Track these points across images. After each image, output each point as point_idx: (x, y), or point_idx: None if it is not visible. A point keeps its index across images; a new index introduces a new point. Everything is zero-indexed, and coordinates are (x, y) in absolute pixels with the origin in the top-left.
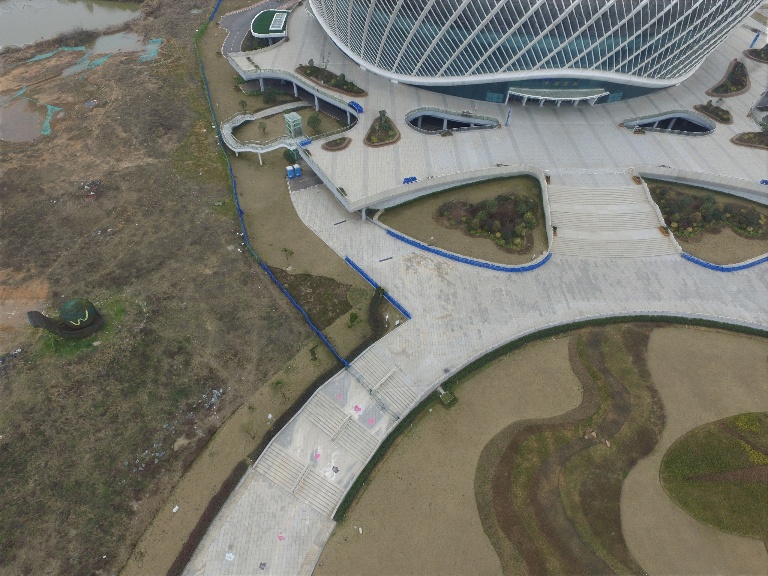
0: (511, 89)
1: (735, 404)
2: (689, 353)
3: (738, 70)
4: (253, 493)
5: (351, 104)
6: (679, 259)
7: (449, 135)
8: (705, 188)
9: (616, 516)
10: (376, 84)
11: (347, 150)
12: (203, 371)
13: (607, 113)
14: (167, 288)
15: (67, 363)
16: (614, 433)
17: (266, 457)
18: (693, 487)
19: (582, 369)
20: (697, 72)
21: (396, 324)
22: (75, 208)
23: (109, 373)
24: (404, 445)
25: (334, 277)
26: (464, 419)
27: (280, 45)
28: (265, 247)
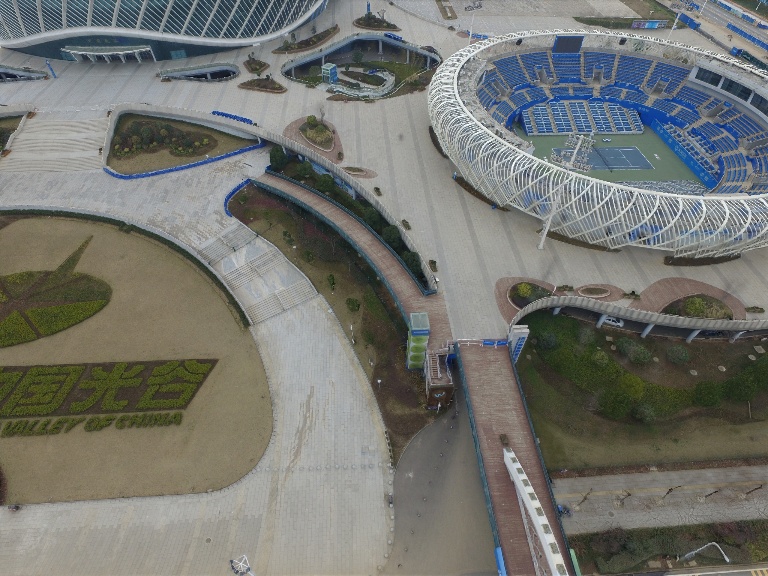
0: (66, 47)
1: (25, 266)
2: (28, 234)
3: (312, 32)
4: None
5: None
6: (99, 172)
7: None
8: (184, 121)
9: None
10: None
11: None
12: None
13: (160, 67)
14: None
15: None
16: None
17: None
18: None
19: None
20: (289, 35)
21: None
22: None
23: None
24: None
25: None
26: None
27: None
28: None
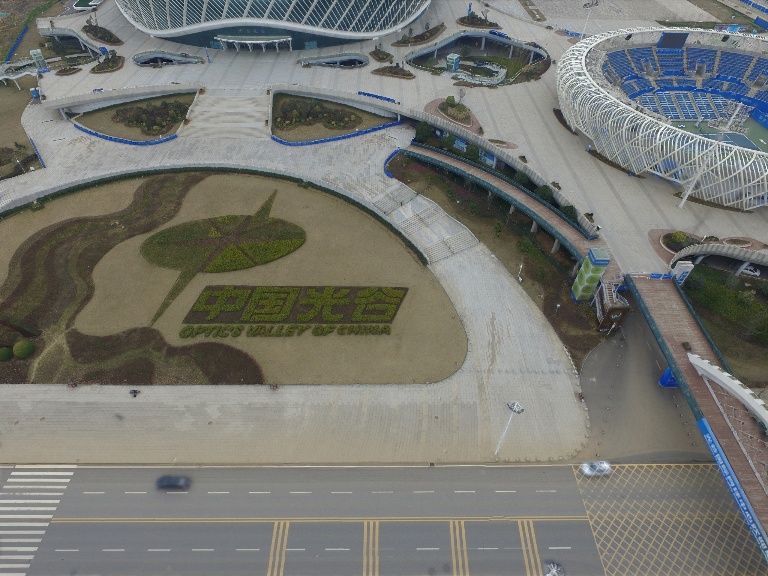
0: (218, 36)
1: (228, 211)
2: (223, 187)
3: (425, 28)
4: None
5: (99, 48)
6: (268, 140)
7: (159, 67)
8: (329, 101)
9: (97, 259)
10: (136, 38)
11: (73, 75)
12: None
13: (297, 55)
14: None
15: None
16: (132, 223)
17: None
18: (159, 247)
19: (140, 193)
20: (402, 31)
21: (32, 170)
22: None
23: None
24: None
25: (13, 148)
26: (40, 216)
27: (86, 14)
28: None
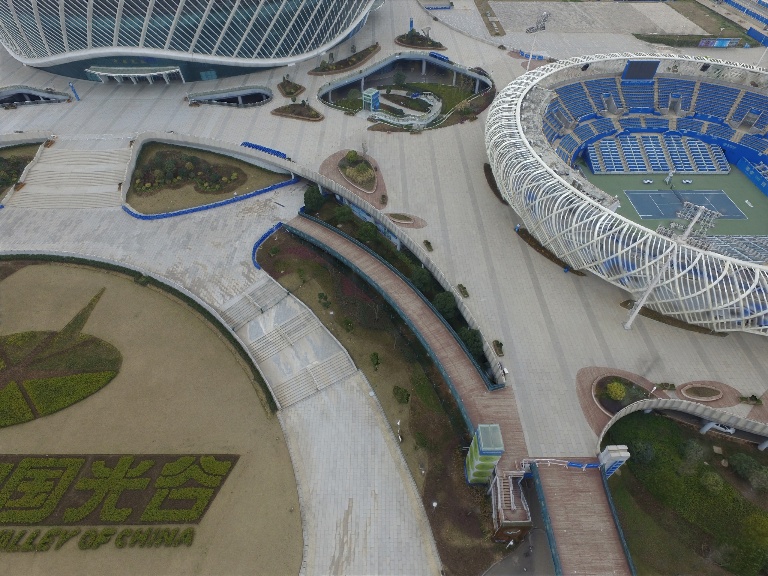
0: (91, 67)
1: (29, 324)
2: (35, 285)
3: (351, 51)
4: None
5: None
6: (118, 210)
7: (12, 108)
8: (211, 152)
9: None
10: (6, 67)
11: None
12: None
13: (189, 89)
14: None
15: None
16: None
17: None
18: None
19: None
20: (326, 54)
21: None
22: None
23: None
24: None
25: None
26: None
27: None
28: None
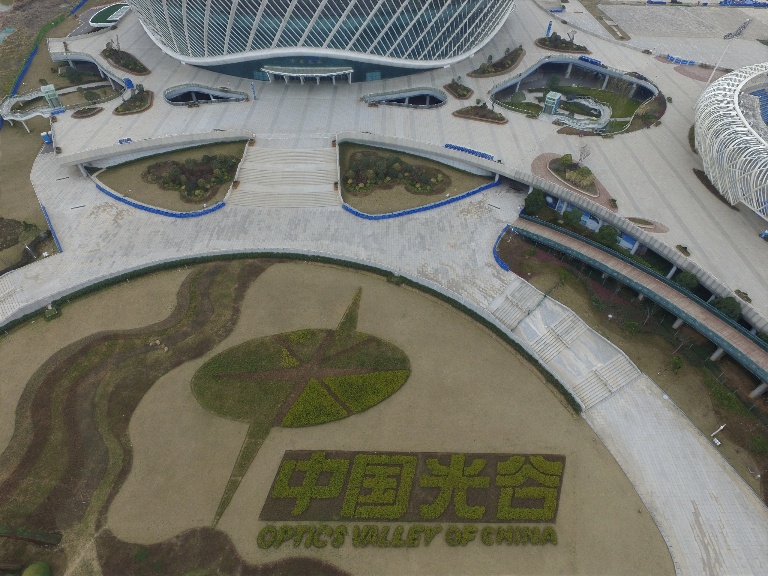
0: (265, 67)
1: (302, 322)
2: (291, 283)
3: (505, 54)
4: None
5: (123, 80)
6: (339, 209)
7: (195, 106)
8: (406, 153)
9: (135, 403)
10: (165, 65)
11: (92, 118)
12: None
13: (358, 90)
14: None
15: None
16: (178, 342)
17: None
18: (216, 383)
19: (185, 293)
20: (475, 57)
21: (44, 256)
22: None
23: None
24: None
25: (21, 220)
26: (56, 329)
27: (104, 33)
28: None
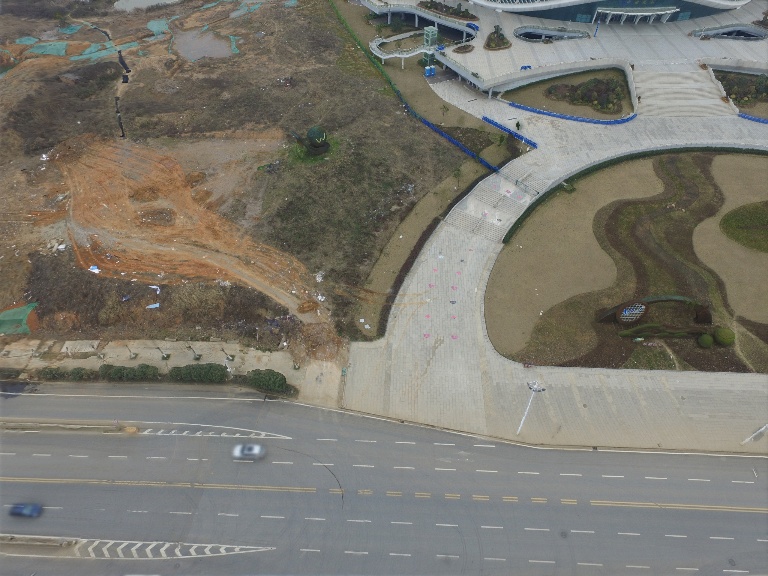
0: (599, 9)
1: None
2: (743, 168)
3: None
4: (447, 231)
5: (469, 24)
6: (736, 117)
7: (550, 43)
8: None
9: (690, 243)
10: (484, 13)
11: (473, 53)
12: (399, 175)
13: (677, 28)
14: (363, 132)
15: (313, 166)
16: (687, 206)
17: (452, 215)
18: (743, 231)
19: (663, 174)
20: None
21: (527, 150)
22: (280, 92)
23: (340, 172)
24: (543, 210)
25: (477, 128)
26: (582, 198)
27: None
28: (422, 113)
